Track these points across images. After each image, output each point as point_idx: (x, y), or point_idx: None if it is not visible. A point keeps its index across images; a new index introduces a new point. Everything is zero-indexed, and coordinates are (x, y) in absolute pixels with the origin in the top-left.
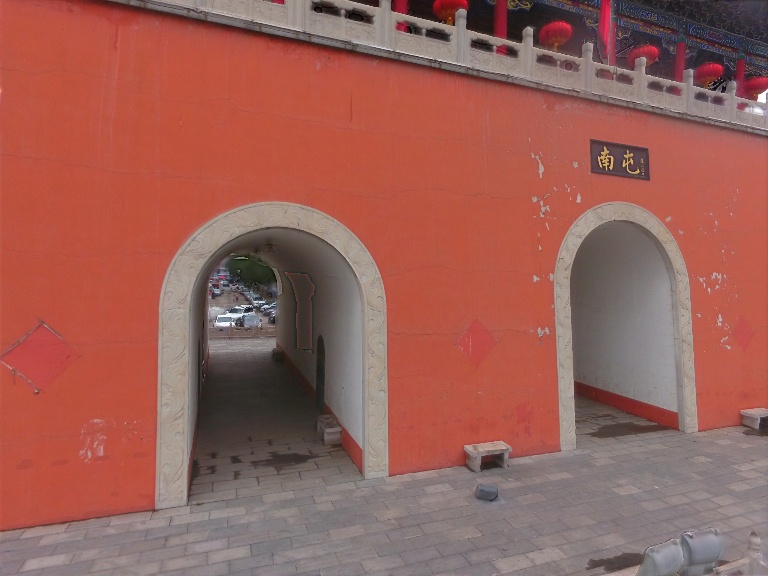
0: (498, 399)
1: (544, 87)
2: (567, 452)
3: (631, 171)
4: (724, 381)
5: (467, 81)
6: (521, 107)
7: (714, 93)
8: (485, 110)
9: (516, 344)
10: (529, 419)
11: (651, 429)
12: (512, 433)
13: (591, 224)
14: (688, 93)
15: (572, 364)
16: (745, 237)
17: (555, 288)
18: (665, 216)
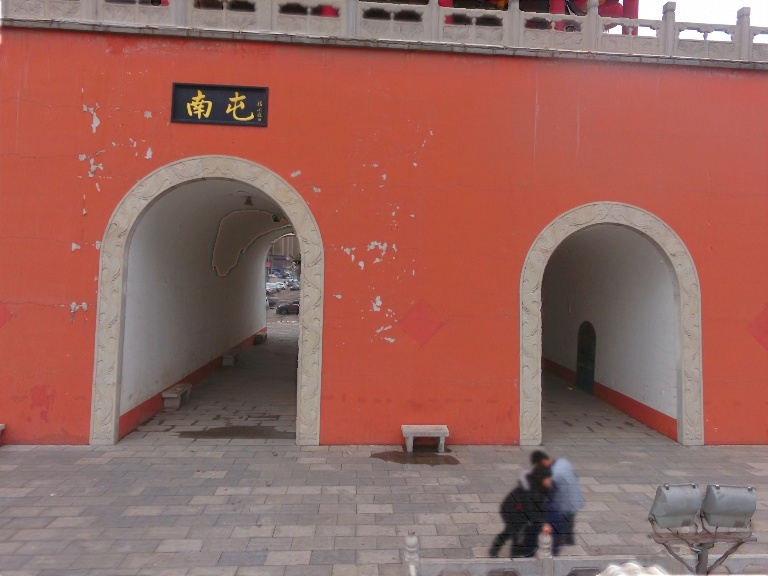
0: (7, 378)
1: (103, 28)
2: (91, 446)
3: (240, 117)
4: (377, 384)
5: (2, 33)
6: (75, 55)
7: (399, 7)
8: (24, 62)
9: (39, 319)
10: (48, 404)
11: (270, 436)
12: (23, 417)
13: (165, 183)
14: (348, 12)
15: (117, 346)
16: (441, 194)
17: (101, 258)
18: (291, 170)
